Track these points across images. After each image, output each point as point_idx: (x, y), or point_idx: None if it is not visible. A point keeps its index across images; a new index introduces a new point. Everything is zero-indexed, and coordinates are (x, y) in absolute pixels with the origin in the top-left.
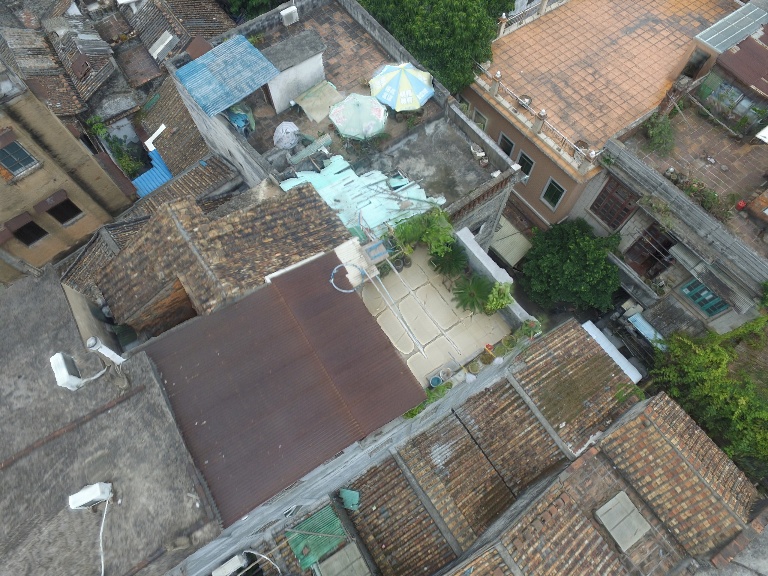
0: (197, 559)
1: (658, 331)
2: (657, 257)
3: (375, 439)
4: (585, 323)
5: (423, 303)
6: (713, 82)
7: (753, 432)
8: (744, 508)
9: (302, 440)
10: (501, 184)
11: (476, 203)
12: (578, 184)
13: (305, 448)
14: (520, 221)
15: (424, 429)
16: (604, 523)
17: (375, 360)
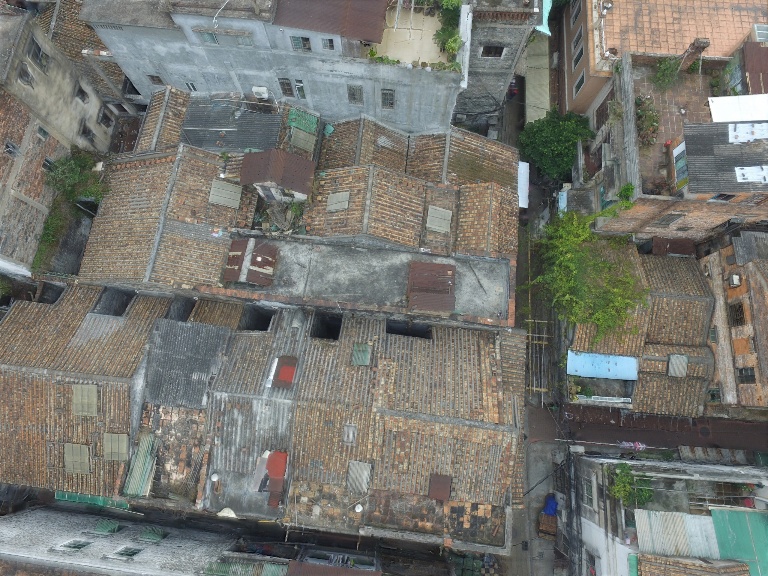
0: (255, 47)
1: (568, 206)
2: None
3: (351, 60)
4: (524, 162)
5: (423, 35)
6: (735, 62)
7: (559, 274)
8: (498, 250)
9: (321, 20)
10: (521, 16)
11: (499, 18)
12: (592, 78)
13: (320, 23)
14: (556, 104)
15: (386, 127)
16: (429, 211)
17: (373, 17)
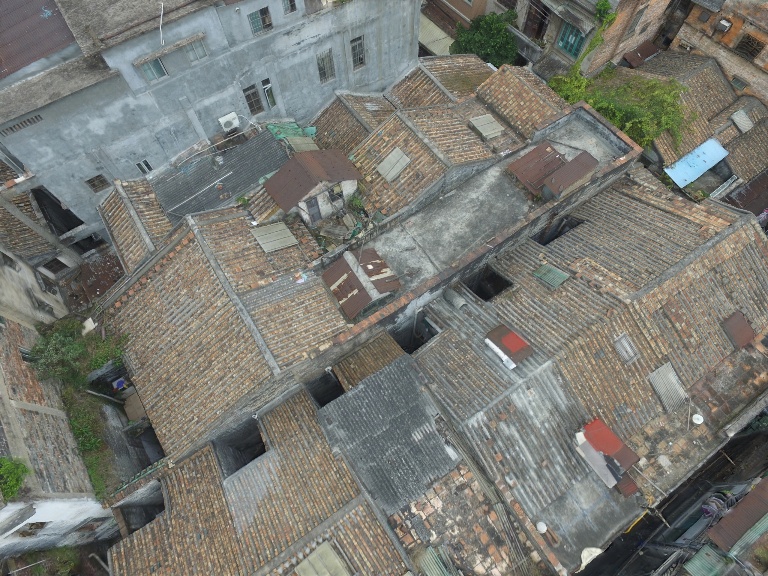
0: (211, 55)
1: (543, 78)
2: (542, 24)
3: (316, 15)
4: None
5: None
6: None
7: None
8: None
9: None
10: None
11: None
12: None
13: None
14: (451, 29)
15: (361, 95)
16: (473, 123)
17: None
